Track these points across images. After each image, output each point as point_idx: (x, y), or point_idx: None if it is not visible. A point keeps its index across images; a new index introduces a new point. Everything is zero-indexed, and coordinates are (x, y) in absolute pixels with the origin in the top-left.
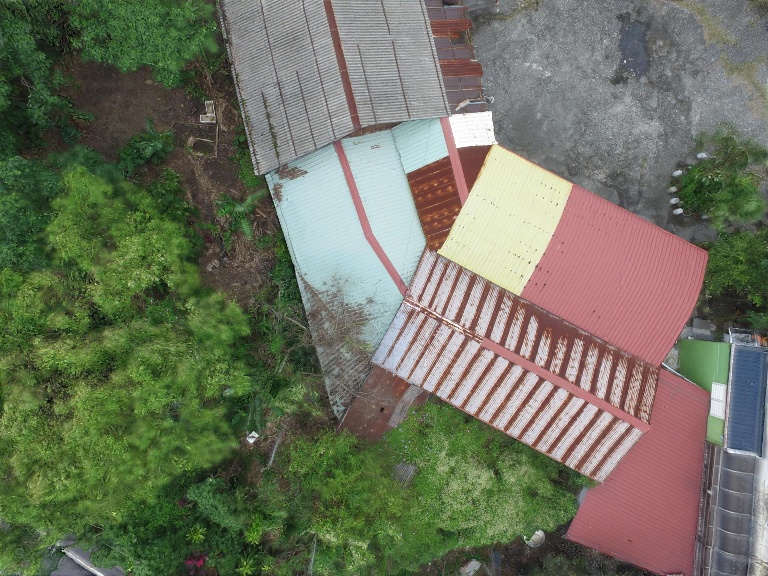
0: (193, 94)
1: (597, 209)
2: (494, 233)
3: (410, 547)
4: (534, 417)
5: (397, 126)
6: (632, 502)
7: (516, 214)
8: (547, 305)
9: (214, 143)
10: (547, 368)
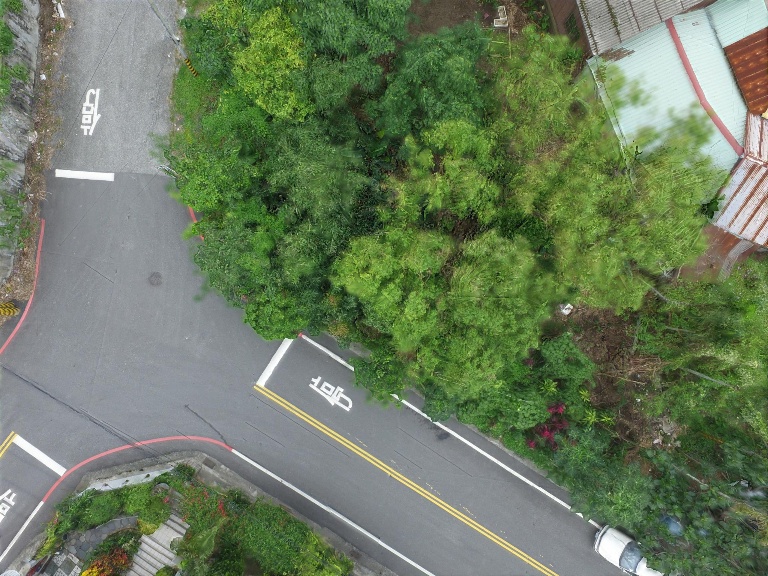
0: (485, 1)
1: None
2: None
3: (745, 390)
4: None
5: (712, 5)
6: None
7: None
8: None
9: (507, 45)
10: None
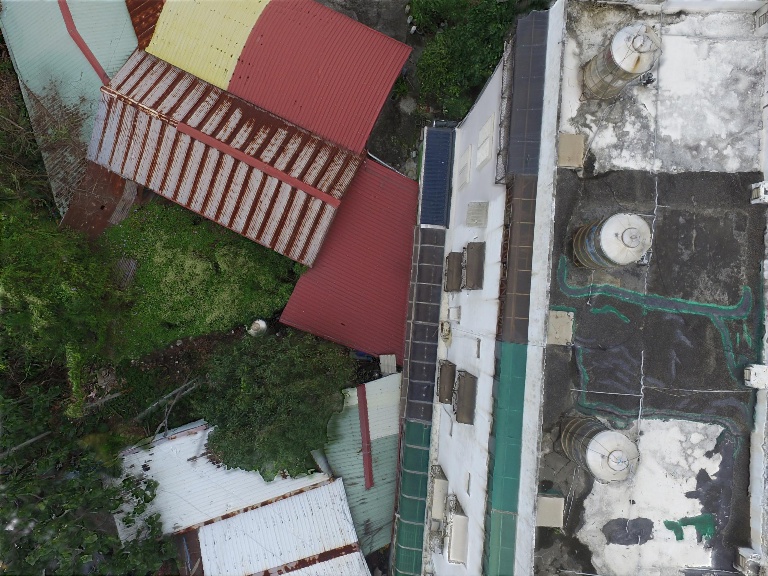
0: None
1: (302, 7)
2: (196, 28)
3: (133, 338)
4: (238, 202)
5: None
6: (344, 288)
7: (217, 9)
8: (252, 98)
9: None
10: (242, 150)
